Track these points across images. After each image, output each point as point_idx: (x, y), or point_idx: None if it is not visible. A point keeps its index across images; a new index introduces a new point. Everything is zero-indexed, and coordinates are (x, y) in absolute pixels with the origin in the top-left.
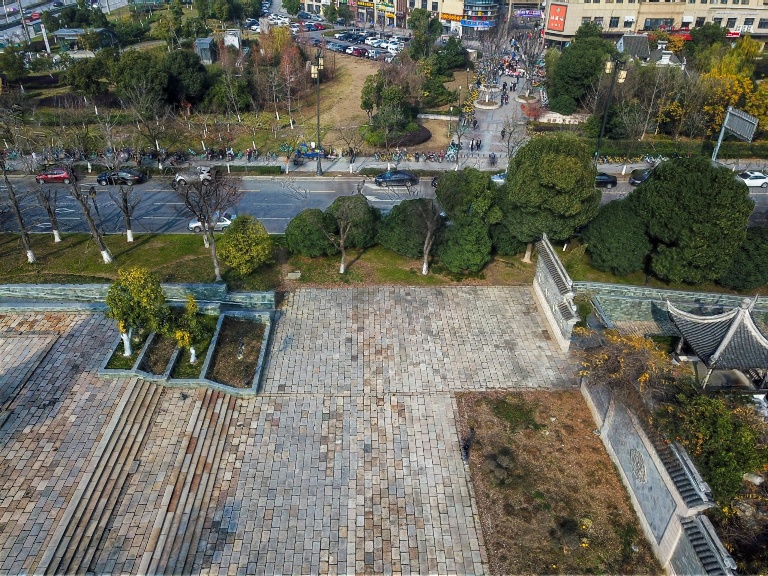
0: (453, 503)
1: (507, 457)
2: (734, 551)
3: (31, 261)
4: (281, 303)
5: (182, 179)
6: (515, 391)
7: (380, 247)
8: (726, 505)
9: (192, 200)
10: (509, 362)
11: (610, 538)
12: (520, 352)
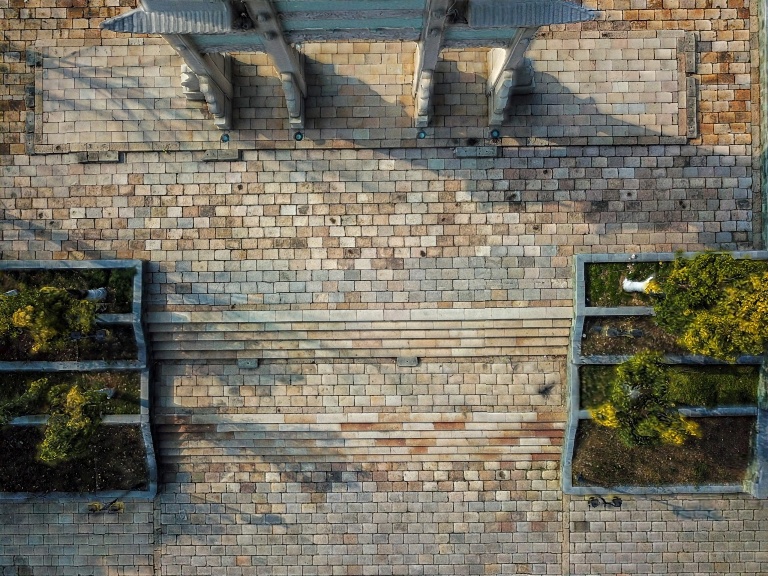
0: None
1: None
2: None
3: None
4: None
5: None
6: None
7: None
8: None
9: None
10: None
11: None
12: None
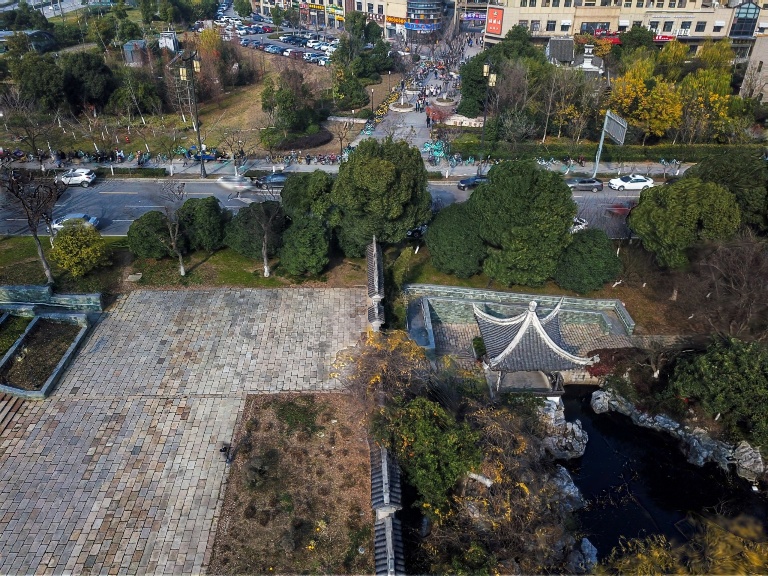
0: (198, 506)
1: (270, 459)
2: (438, 553)
3: None
4: (111, 305)
5: None
6: (308, 393)
7: (231, 249)
8: (438, 507)
9: None
10: (315, 364)
11: (340, 540)
12: (330, 354)
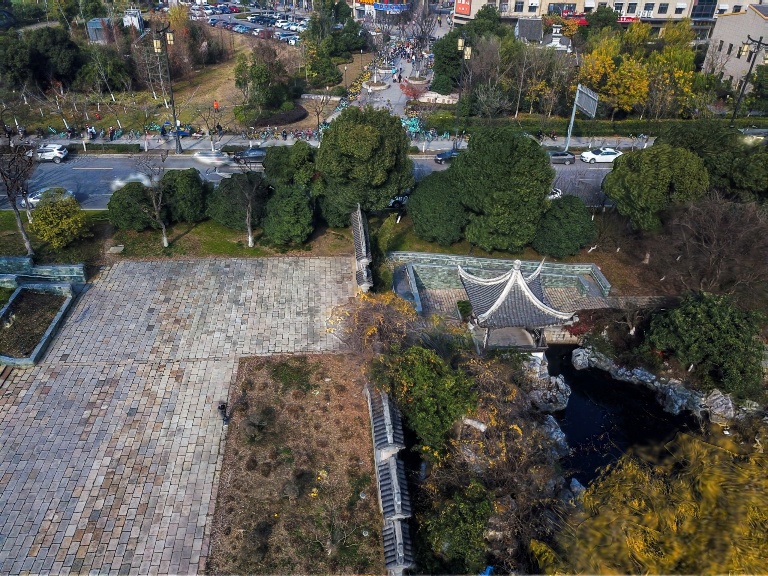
0: (199, 461)
1: (267, 416)
2: (438, 492)
3: None
4: (94, 276)
5: None
6: (300, 355)
7: (213, 221)
8: (437, 449)
9: None
10: (305, 328)
11: (342, 487)
12: (319, 318)
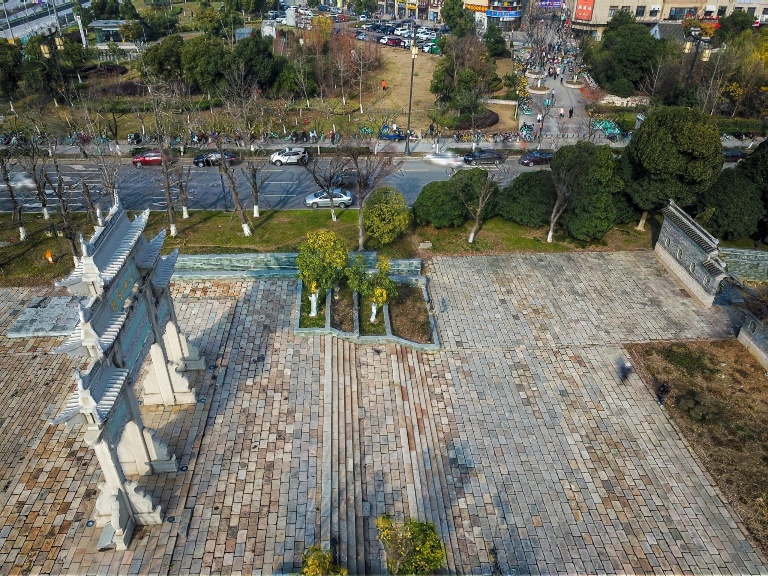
0: (663, 437)
1: None
2: None
3: (174, 235)
4: (423, 270)
5: (278, 160)
6: (678, 342)
7: (498, 218)
8: None
9: (318, 175)
10: (661, 317)
11: None
12: (668, 308)
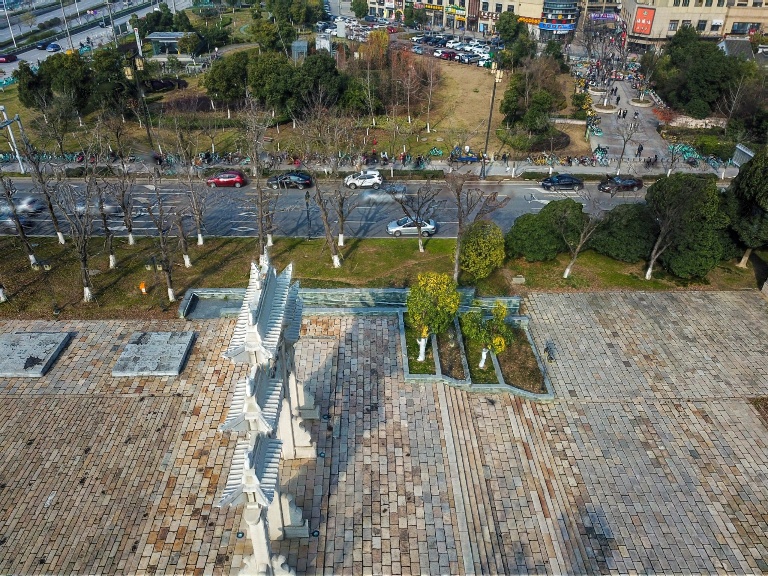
0: None
1: None
2: None
3: None
4: (520, 308)
5: (353, 183)
6: None
7: (590, 252)
8: None
9: (406, 204)
10: None
11: None
12: None
